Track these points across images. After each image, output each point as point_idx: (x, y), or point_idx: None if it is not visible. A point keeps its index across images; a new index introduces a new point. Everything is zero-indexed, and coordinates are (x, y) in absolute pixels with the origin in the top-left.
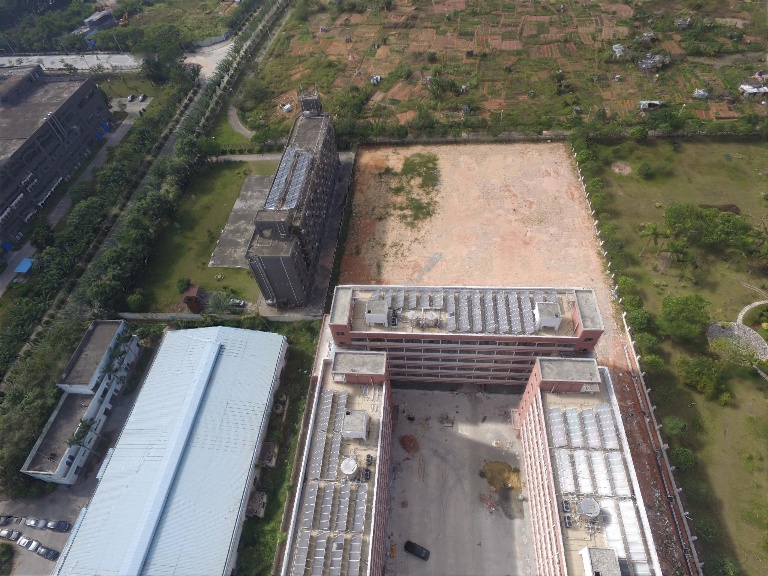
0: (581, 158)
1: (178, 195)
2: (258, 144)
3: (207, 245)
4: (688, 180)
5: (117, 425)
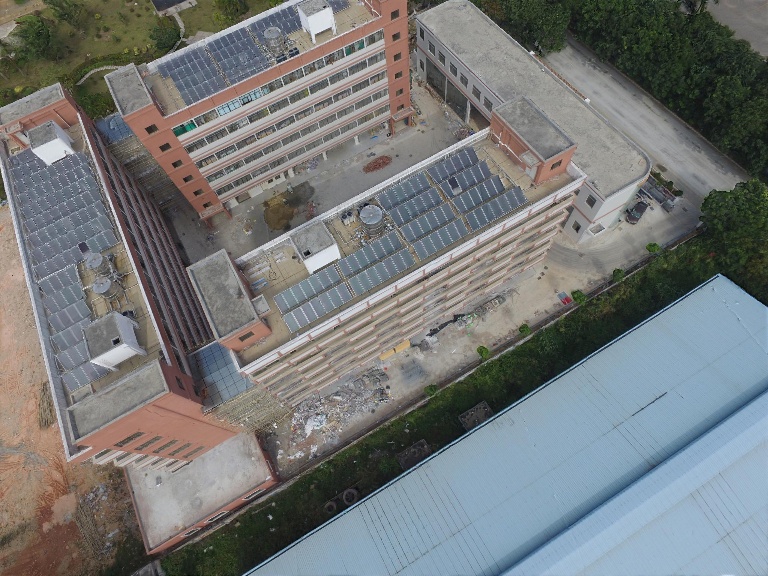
0: None
1: None
2: None
3: None
4: None
5: None
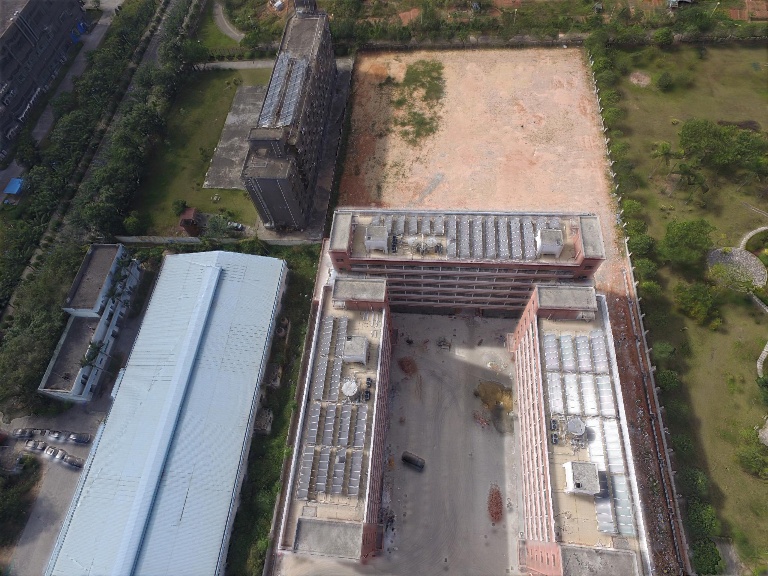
0: (598, 67)
1: (165, 108)
2: (248, 49)
3: (200, 164)
4: (711, 93)
5: (125, 346)
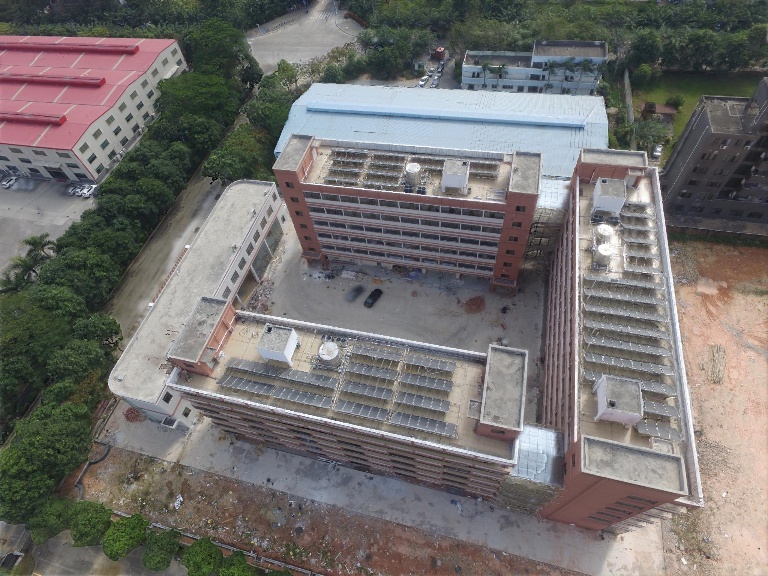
0: None
1: None
2: None
3: None
4: None
5: None
